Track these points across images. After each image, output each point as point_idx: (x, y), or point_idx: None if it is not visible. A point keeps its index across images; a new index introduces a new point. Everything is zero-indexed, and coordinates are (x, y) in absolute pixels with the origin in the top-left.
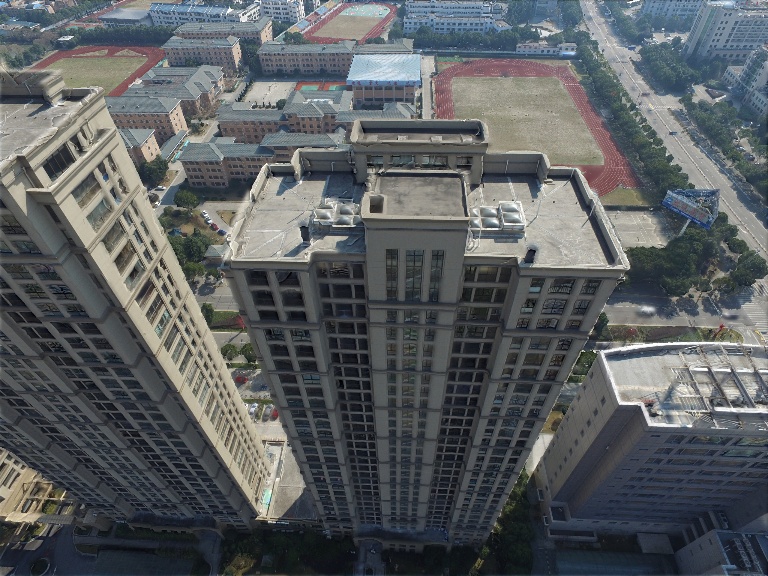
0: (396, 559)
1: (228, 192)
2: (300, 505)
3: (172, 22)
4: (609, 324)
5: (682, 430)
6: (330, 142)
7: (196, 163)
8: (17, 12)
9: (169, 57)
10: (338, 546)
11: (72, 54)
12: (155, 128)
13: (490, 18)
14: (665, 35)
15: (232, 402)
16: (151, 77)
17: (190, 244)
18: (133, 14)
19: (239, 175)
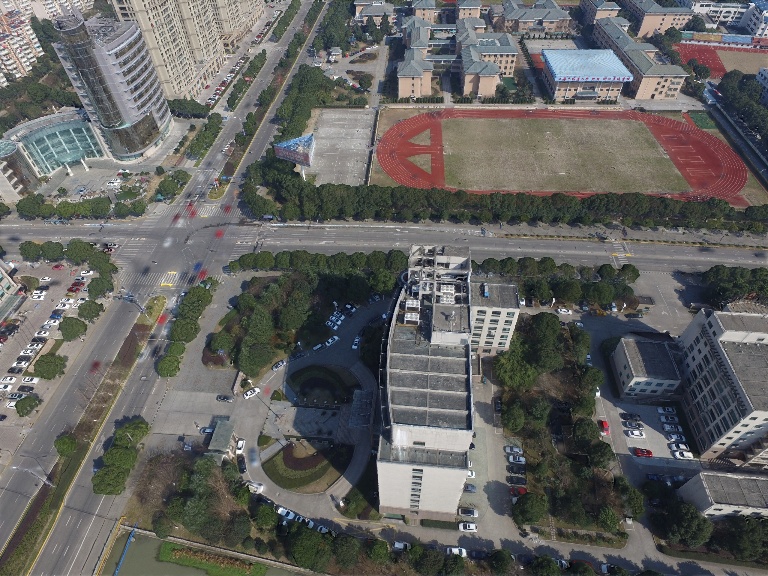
0: None
1: None
2: None
3: None
4: (245, 153)
5: (102, 29)
6: (413, 43)
7: None
8: None
9: None
10: None
11: None
12: None
13: None
14: None
15: (178, 5)
16: (537, 3)
17: (330, 36)
18: None
19: None
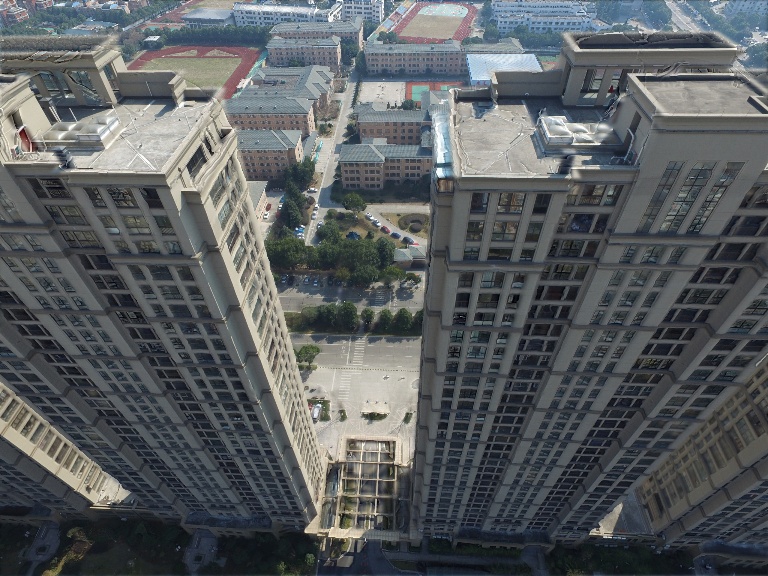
0: (736, 575)
1: (384, 194)
2: (626, 519)
3: (255, 22)
4: None
5: None
6: None
7: (356, 165)
8: (92, 12)
9: (271, 57)
10: (671, 561)
11: (162, 54)
12: (290, 129)
13: (587, 17)
14: (761, 34)
15: None
16: (262, 77)
17: (385, 248)
18: (217, 14)
19: (394, 177)
